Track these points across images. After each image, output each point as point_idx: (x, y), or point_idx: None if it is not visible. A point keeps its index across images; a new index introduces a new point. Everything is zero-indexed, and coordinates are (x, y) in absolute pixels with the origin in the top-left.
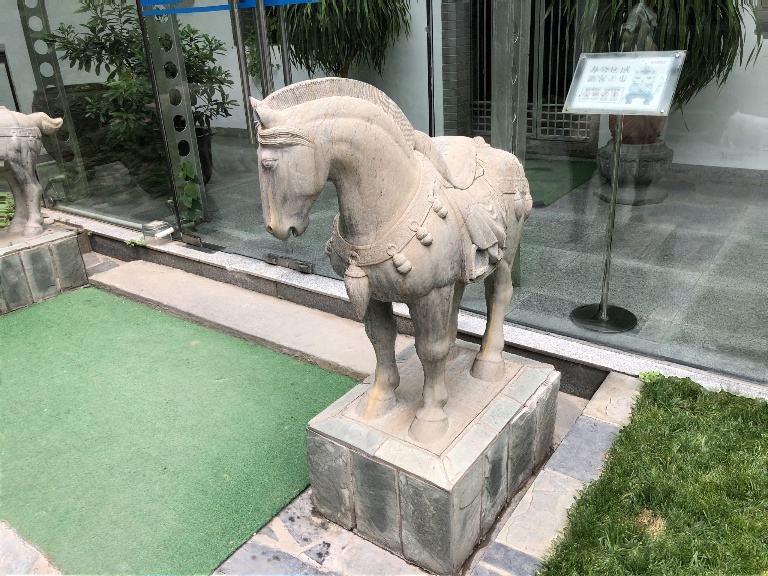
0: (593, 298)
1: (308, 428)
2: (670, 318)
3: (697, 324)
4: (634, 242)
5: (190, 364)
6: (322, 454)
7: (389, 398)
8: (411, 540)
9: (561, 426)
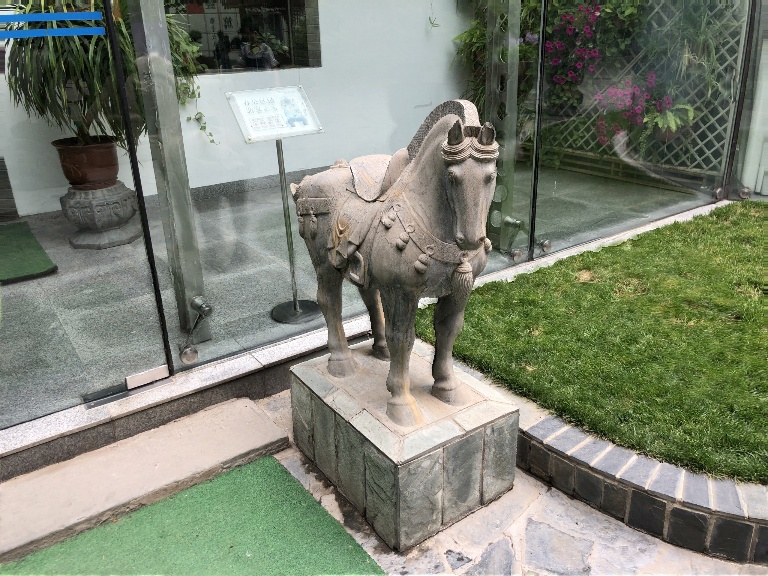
0: (262, 306)
1: (399, 466)
2: None
3: None
4: None
5: None
6: (417, 478)
7: None
8: (490, 482)
9: None
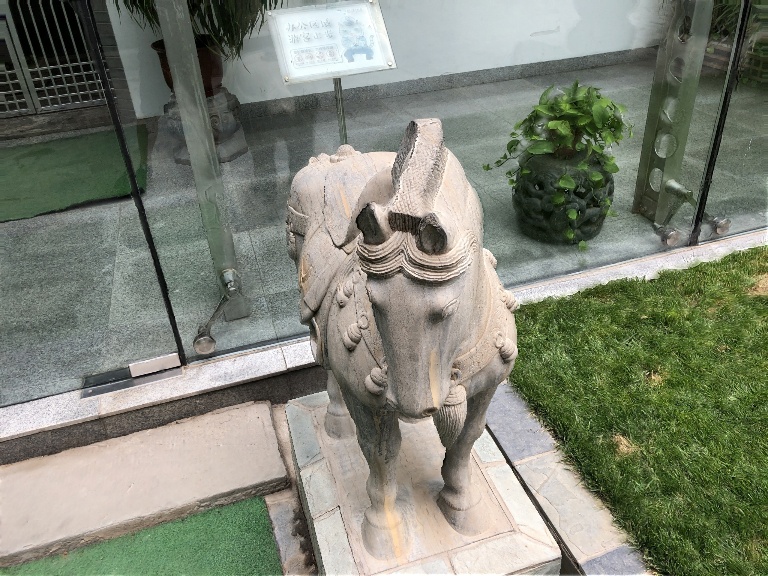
0: None
1: None
2: None
3: None
4: (277, 201)
5: None
6: None
7: (401, 512)
8: None
9: None
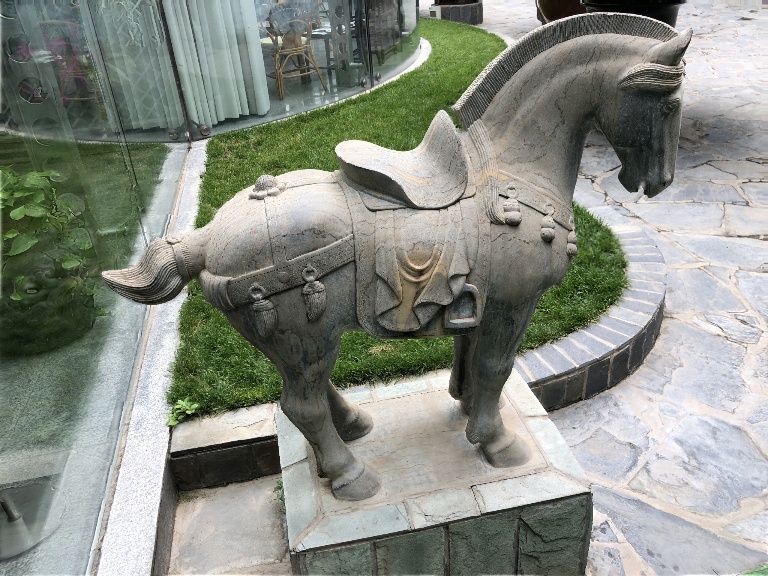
0: None
1: None
2: None
3: None
4: None
5: None
6: None
7: None
8: None
9: (250, 504)
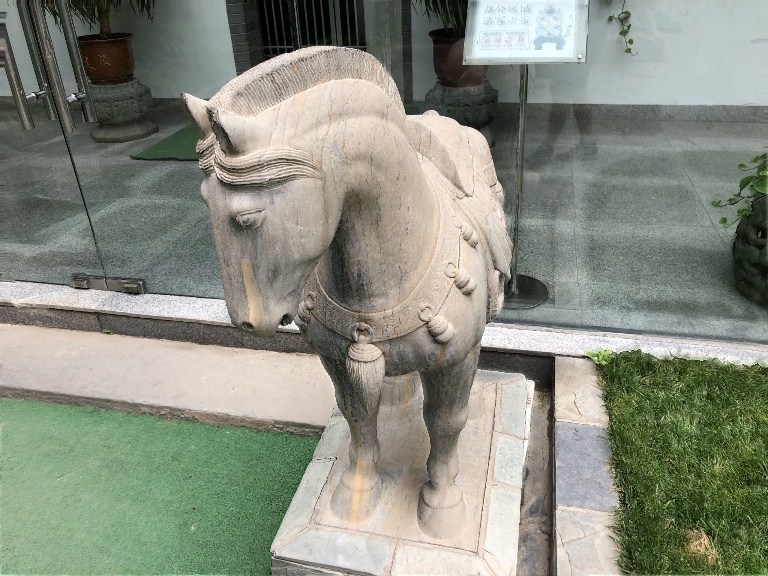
0: None
1: (273, 557)
2: (574, 278)
3: (602, 281)
4: None
5: (6, 463)
6: None
7: (375, 483)
8: None
9: None
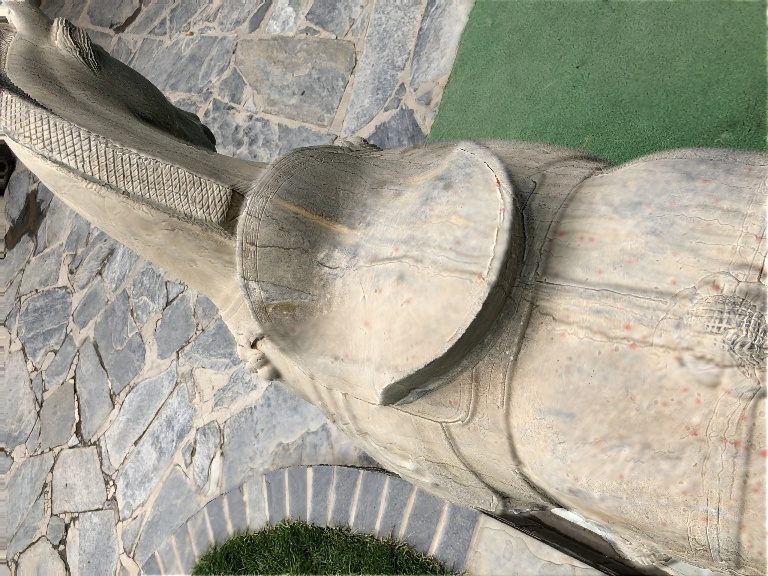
0: None
1: None
2: None
3: None
4: None
5: None
6: None
7: None
8: None
9: None
